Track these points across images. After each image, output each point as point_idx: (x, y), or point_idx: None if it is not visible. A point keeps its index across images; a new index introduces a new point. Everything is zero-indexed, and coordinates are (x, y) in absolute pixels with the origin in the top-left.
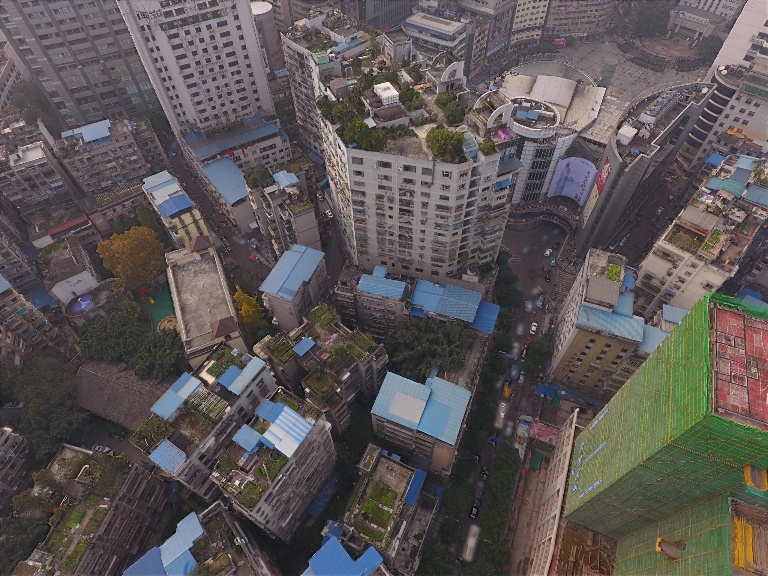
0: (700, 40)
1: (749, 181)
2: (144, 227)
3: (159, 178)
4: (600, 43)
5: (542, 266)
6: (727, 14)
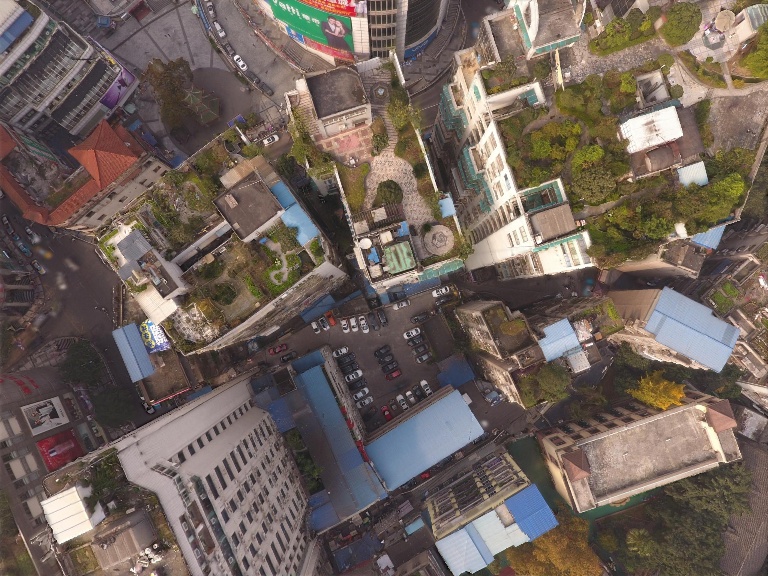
0: None
1: None
2: (553, 552)
3: (459, 551)
4: None
5: None
6: None
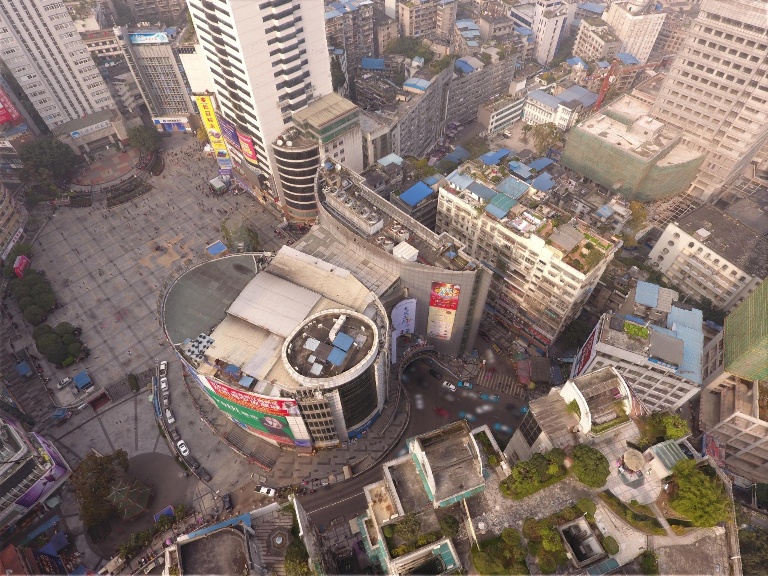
0: (121, 140)
1: (490, 187)
2: None
3: None
4: (49, 222)
5: (473, 399)
6: (107, 105)
